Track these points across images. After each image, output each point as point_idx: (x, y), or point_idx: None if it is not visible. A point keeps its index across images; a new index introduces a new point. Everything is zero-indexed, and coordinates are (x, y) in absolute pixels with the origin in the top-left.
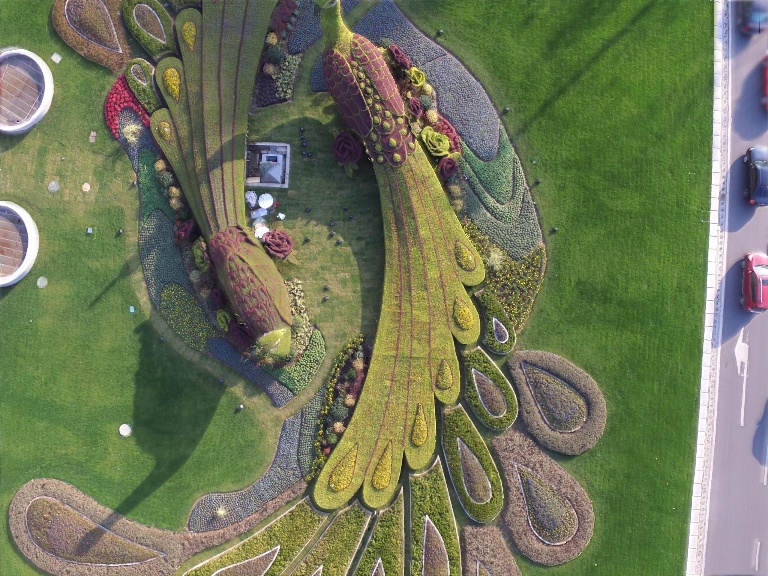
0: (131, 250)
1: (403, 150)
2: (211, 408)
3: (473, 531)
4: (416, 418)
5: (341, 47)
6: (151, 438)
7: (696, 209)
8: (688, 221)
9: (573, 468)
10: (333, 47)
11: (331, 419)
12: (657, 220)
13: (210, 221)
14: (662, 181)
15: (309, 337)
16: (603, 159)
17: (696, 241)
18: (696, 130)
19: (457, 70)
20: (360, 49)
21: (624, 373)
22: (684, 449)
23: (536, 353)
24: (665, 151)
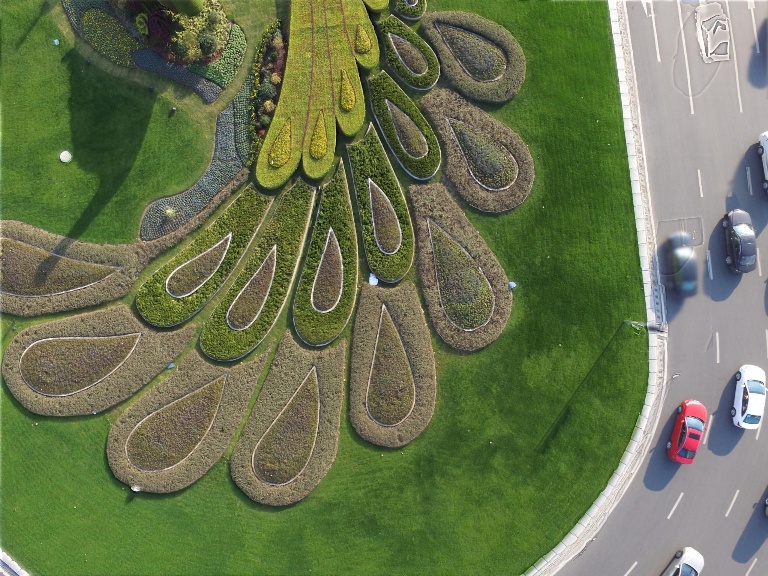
0: None
1: None
2: (145, 117)
3: (417, 188)
4: (342, 83)
5: None
6: (92, 159)
7: None
8: None
9: (503, 116)
10: None
11: (260, 99)
12: None
13: None
14: None
15: (229, 32)
16: None
17: None
18: None
19: None
20: None
21: (536, 22)
22: (607, 87)
23: (447, 11)
24: None
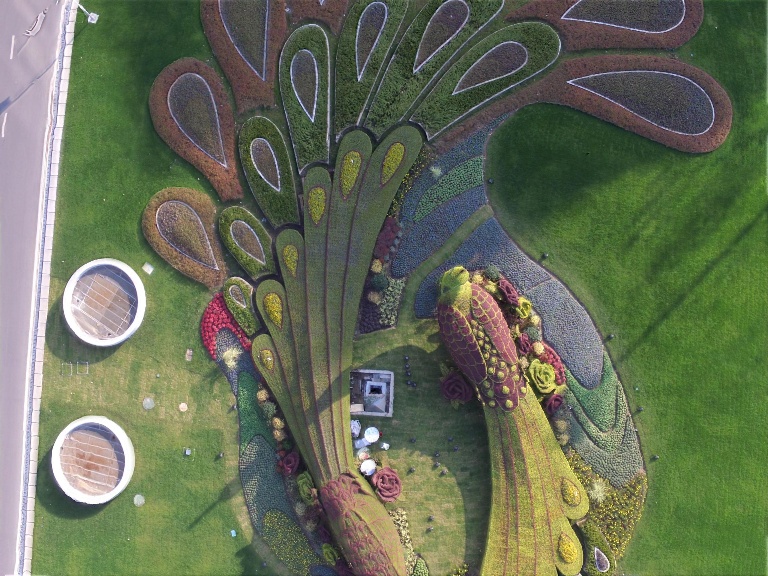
0: (232, 474)
1: (516, 396)
2: None
3: None
4: None
5: (460, 304)
6: None
7: None
8: None
9: None
10: (452, 303)
11: None
12: (754, 444)
13: (321, 466)
14: (761, 405)
15: (413, 566)
16: (704, 385)
17: None
18: None
19: (562, 296)
20: (480, 308)
21: None
22: None
23: None
24: (764, 375)
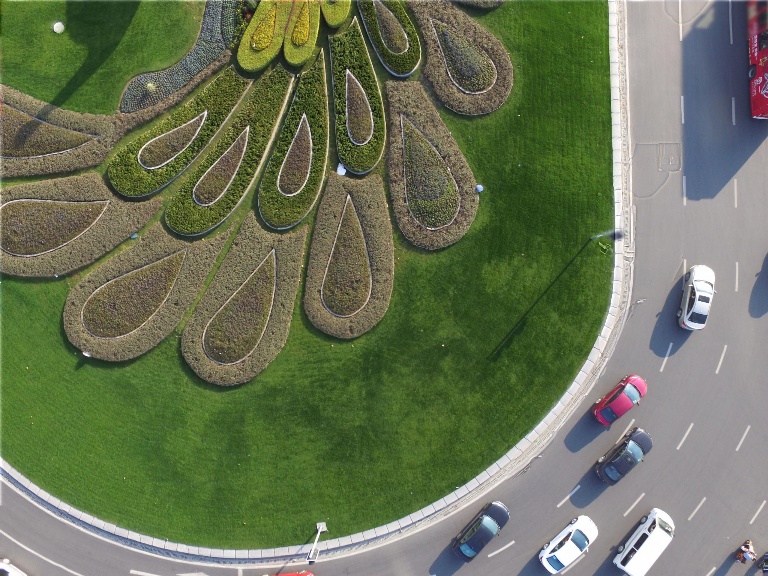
0: None
1: None
2: None
3: (394, 84)
4: None
5: None
6: (83, 31)
7: None
8: None
9: (487, 23)
10: None
11: None
12: None
13: None
14: None
15: None
16: None
17: None
18: None
19: None
20: None
21: None
22: (596, 5)
23: None
24: None
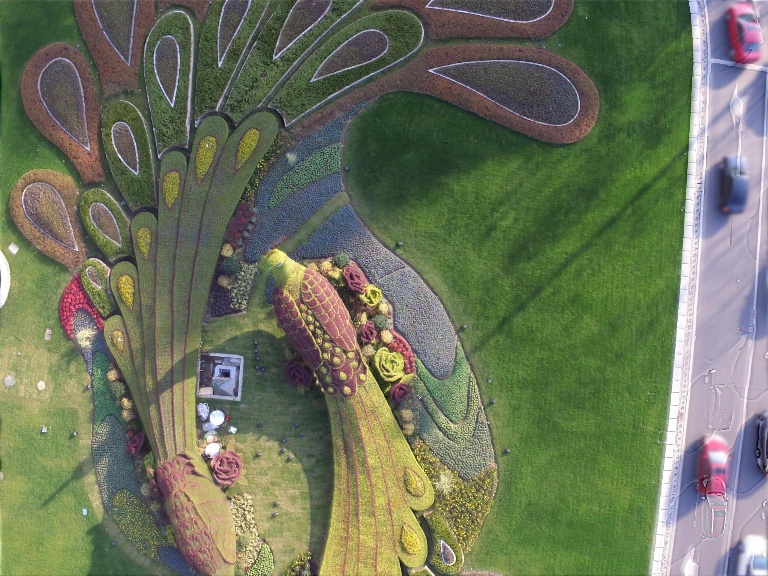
0: (85, 453)
1: (354, 383)
2: None
3: None
4: None
5: (291, 288)
6: None
7: (653, 430)
8: (644, 442)
9: None
10: (283, 287)
11: None
12: (612, 442)
13: (159, 446)
14: (620, 402)
15: (258, 551)
16: (560, 379)
17: (651, 462)
18: (658, 349)
19: (415, 285)
20: (310, 292)
21: None
22: None
23: (483, 575)
24: (625, 371)
